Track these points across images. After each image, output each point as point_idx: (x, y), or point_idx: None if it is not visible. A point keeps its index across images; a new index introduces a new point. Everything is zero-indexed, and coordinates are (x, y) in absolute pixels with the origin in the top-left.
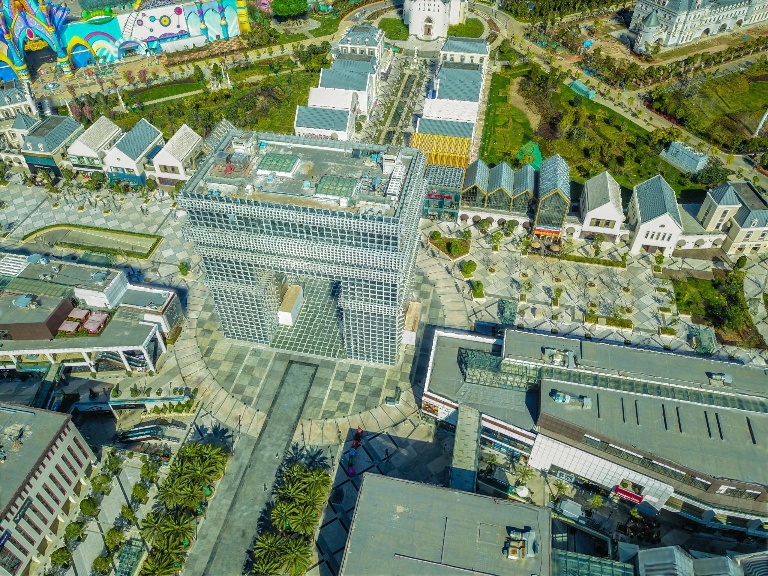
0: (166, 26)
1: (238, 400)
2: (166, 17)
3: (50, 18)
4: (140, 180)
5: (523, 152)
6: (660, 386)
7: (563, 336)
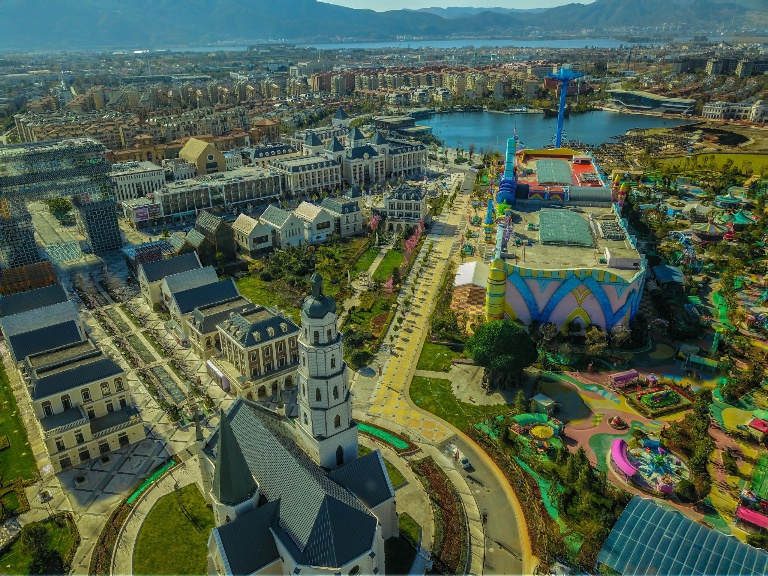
0: None
1: (76, 230)
2: None
3: None
4: None
5: None
6: None
7: None
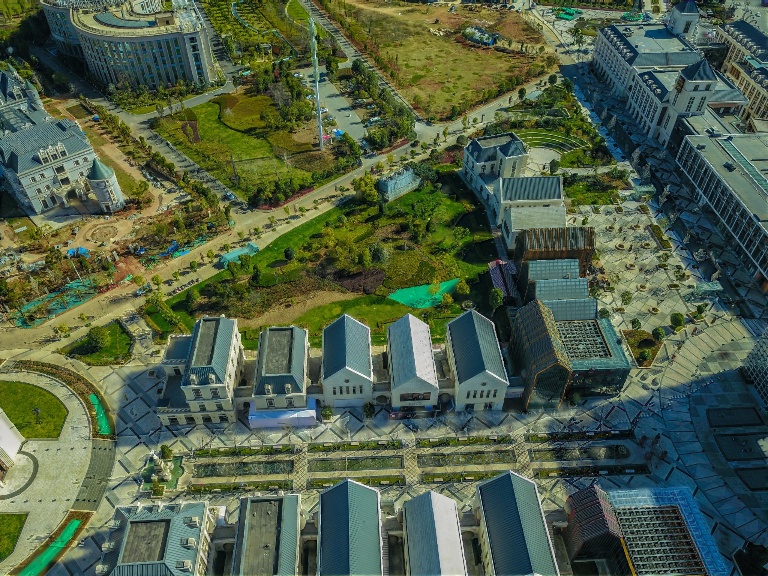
0: None
1: None
2: None
3: None
4: None
5: (418, 302)
6: (764, 189)
7: (695, 262)
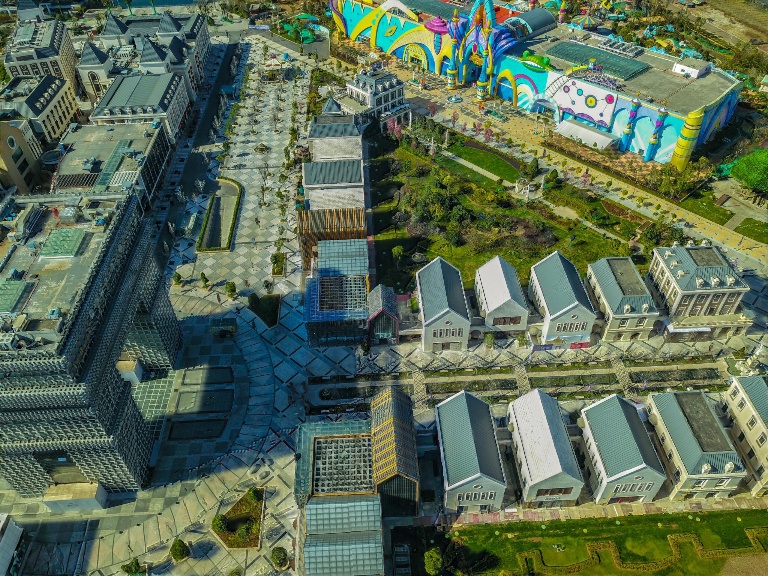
0: (590, 107)
1: None
2: (594, 98)
3: (494, 43)
4: (305, 203)
5: None
6: None
7: None
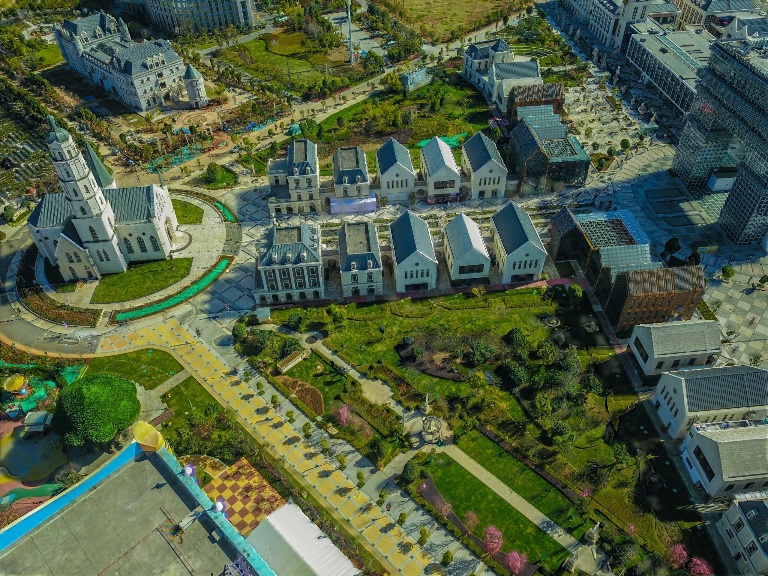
0: None
1: None
2: None
3: None
4: None
5: None
6: None
7: (640, 116)
